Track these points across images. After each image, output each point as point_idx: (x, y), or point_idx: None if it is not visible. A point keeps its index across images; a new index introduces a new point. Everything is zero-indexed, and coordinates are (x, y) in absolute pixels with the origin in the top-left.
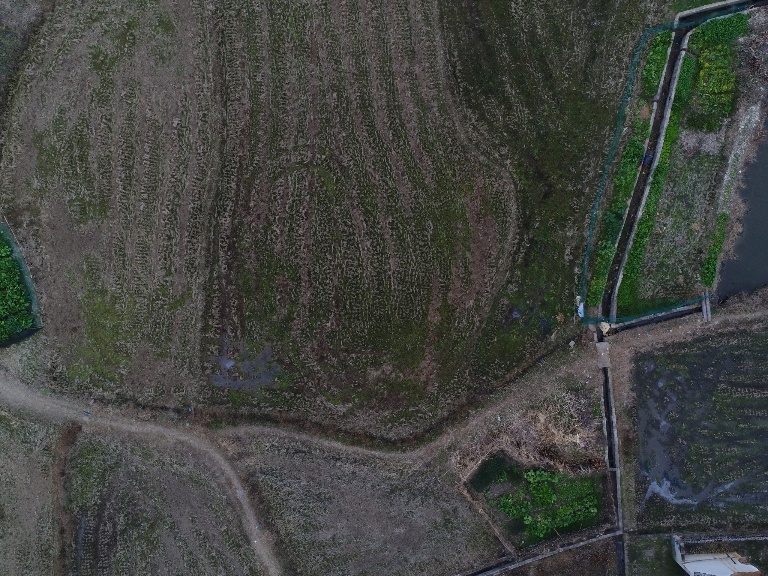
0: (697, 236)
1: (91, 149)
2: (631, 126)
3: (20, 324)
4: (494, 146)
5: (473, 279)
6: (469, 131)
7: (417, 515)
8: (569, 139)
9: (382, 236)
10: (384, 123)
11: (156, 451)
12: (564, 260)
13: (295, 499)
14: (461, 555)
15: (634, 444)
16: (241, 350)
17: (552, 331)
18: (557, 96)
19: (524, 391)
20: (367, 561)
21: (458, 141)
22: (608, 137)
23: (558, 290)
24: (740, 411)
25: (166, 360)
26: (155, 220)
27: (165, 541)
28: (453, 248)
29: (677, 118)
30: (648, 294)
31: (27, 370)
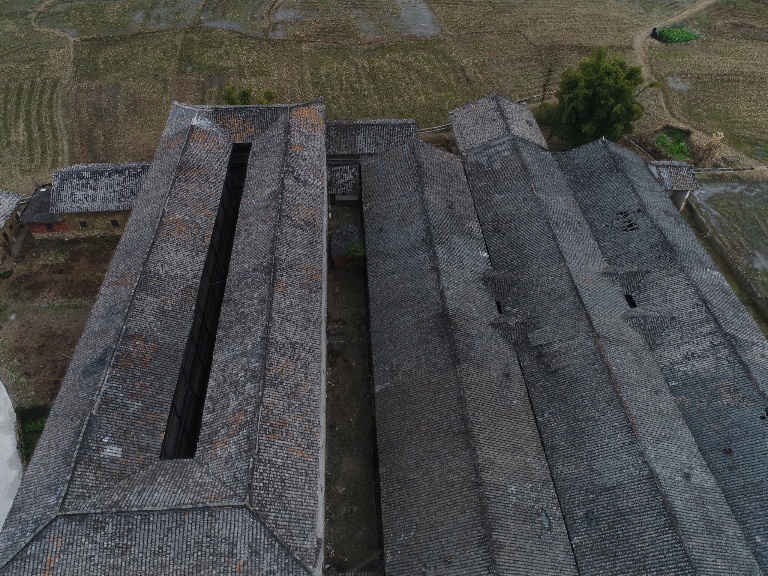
0: None
1: None
2: None
3: None
4: None
5: None
6: None
7: None
8: None
9: (766, 112)
10: None
11: None
12: None
13: None
14: None
15: (719, 179)
16: None
17: None
18: None
19: None
20: None
21: None
22: None
23: None
24: (764, 215)
25: None
26: None
27: None
28: None
29: None
30: None
31: None
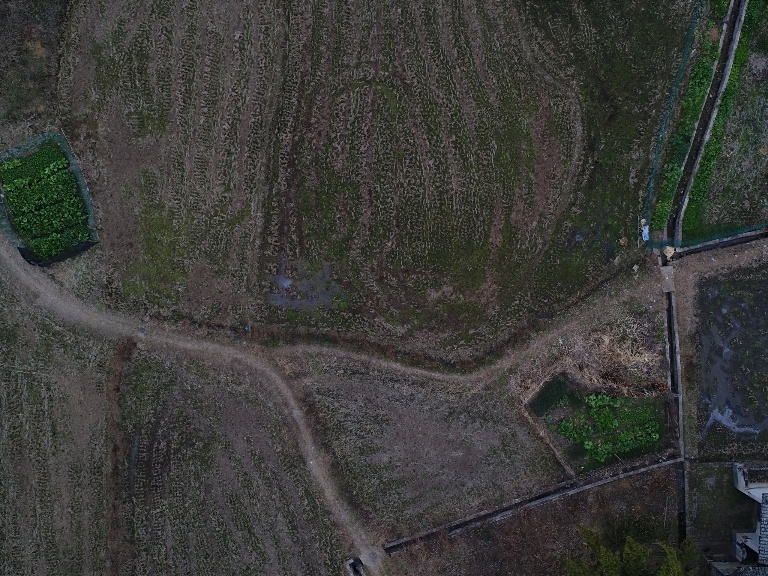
0: (764, 161)
1: (151, 62)
2: (700, 48)
3: (76, 237)
4: (560, 66)
5: (536, 201)
6: (535, 50)
7: (475, 439)
8: (636, 60)
9: (445, 155)
10: (449, 40)
11: (212, 369)
12: (629, 183)
13: (352, 421)
14: (520, 479)
15: (697, 370)
16: (299, 269)
17: (615, 255)
18: (625, 16)
19: (586, 314)
20: (424, 485)
21: (524, 60)
22: (676, 59)
23: (622, 213)
24: None
25: (223, 277)
26: (215, 135)
27: (219, 461)
28: (517, 169)
29: (746, 40)
30: (713, 219)
31: (82, 285)
